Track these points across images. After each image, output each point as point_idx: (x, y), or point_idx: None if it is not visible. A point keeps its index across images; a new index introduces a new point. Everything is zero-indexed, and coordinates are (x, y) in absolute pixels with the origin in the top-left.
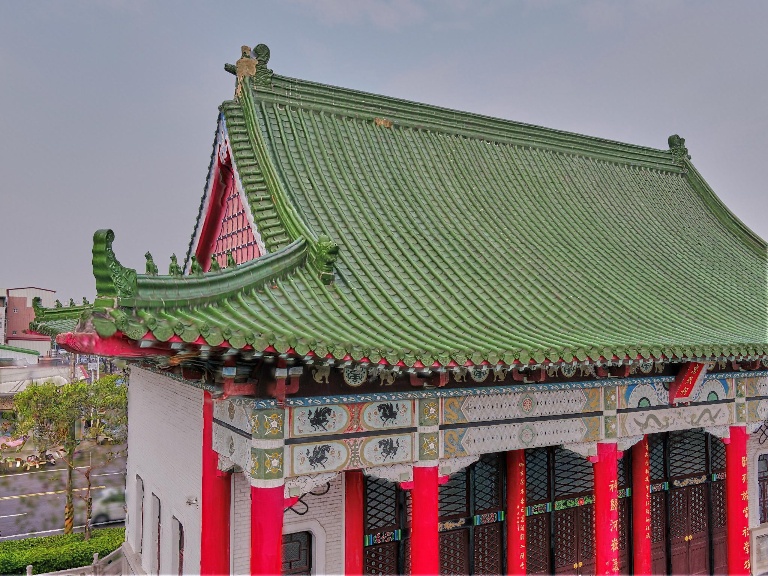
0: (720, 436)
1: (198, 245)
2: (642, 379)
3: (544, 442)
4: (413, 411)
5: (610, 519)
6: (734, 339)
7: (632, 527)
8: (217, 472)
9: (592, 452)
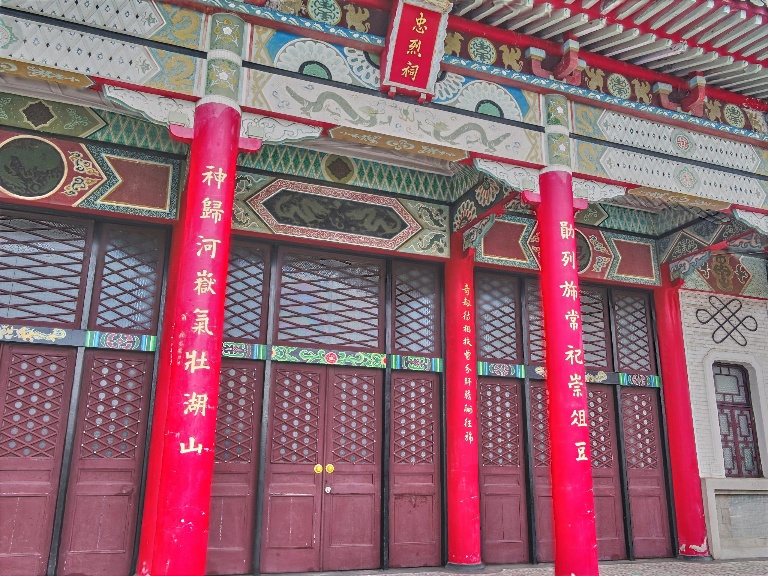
0: (516, 185)
1: None
2: (301, 19)
3: (41, 58)
4: None
5: (198, 233)
6: None
7: (445, 424)
8: None
9: (178, 118)
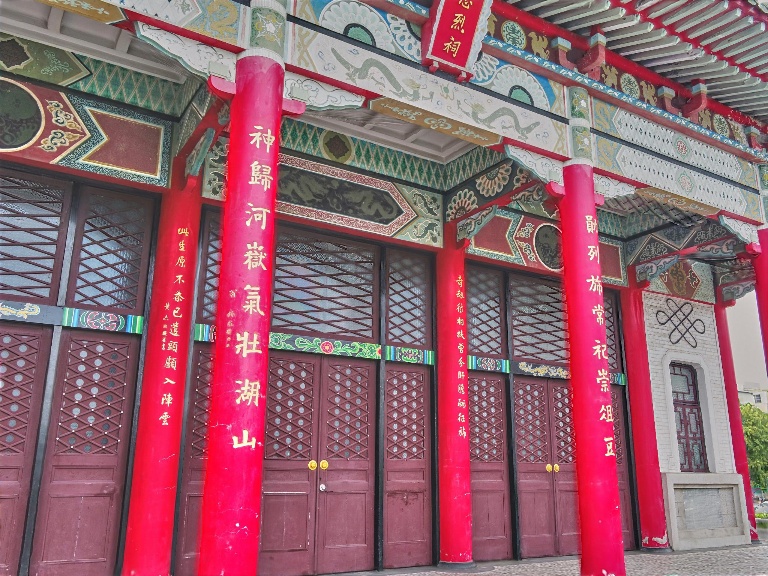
0: (543, 175)
1: None
2: None
3: None
4: None
5: (247, 200)
6: None
7: (436, 419)
8: None
9: (219, 69)
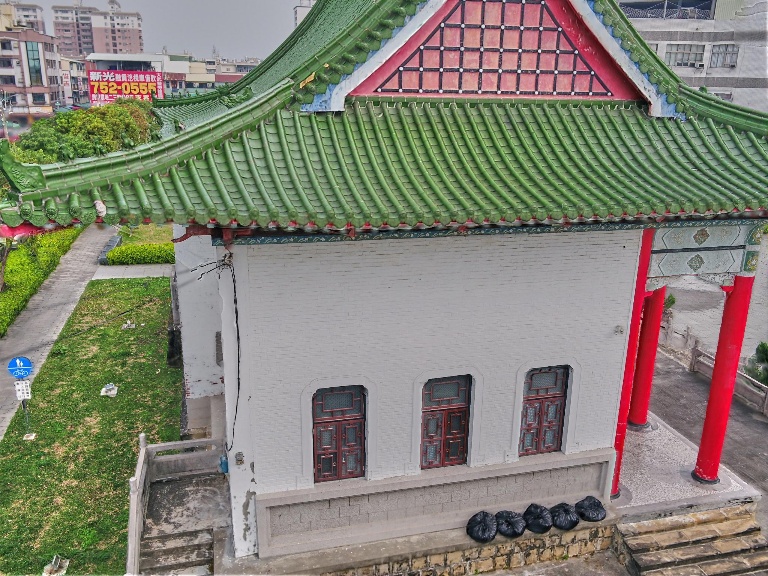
0: None
1: (395, 52)
2: None
3: None
4: None
5: None
6: None
7: None
8: (646, 294)
9: None
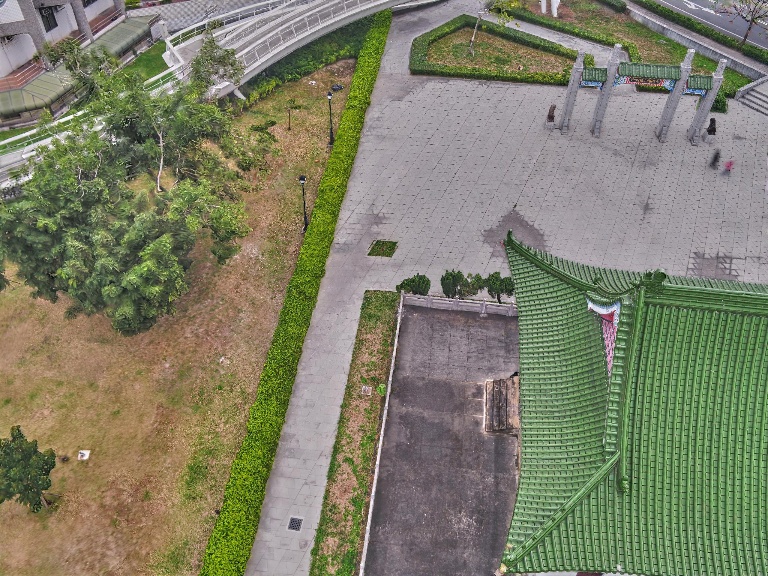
0: None
1: None
2: None
3: None
4: None
5: None
6: (760, 288)
7: None
8: None
9: None
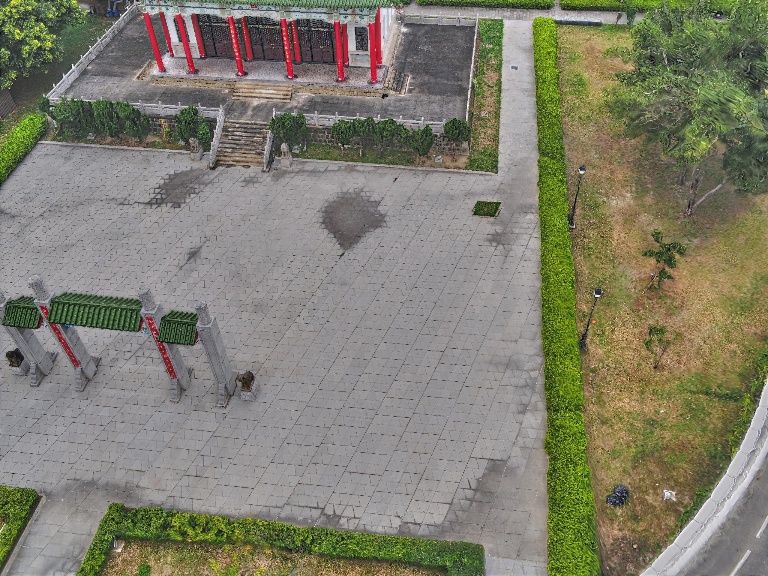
0: None
1: None
2: None
3: (208, 13)
4: (171, 2)
5: (231, 34)
6: None
7: None
8: None
9: None
